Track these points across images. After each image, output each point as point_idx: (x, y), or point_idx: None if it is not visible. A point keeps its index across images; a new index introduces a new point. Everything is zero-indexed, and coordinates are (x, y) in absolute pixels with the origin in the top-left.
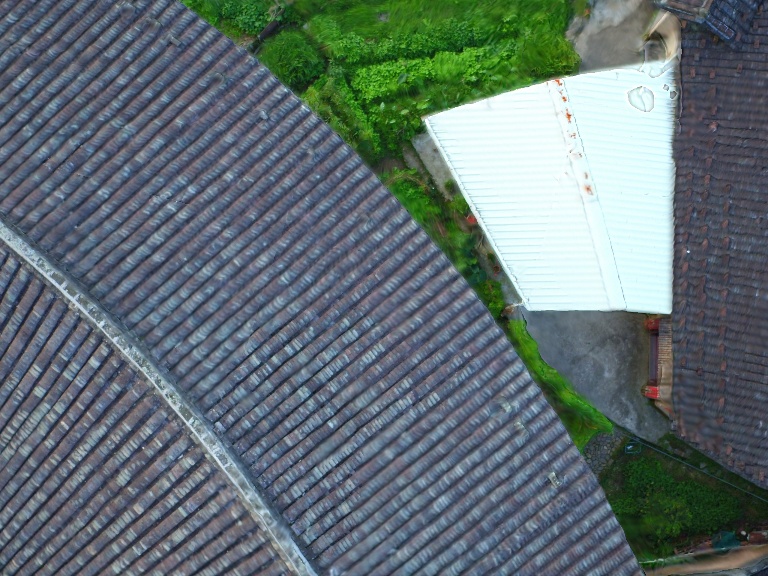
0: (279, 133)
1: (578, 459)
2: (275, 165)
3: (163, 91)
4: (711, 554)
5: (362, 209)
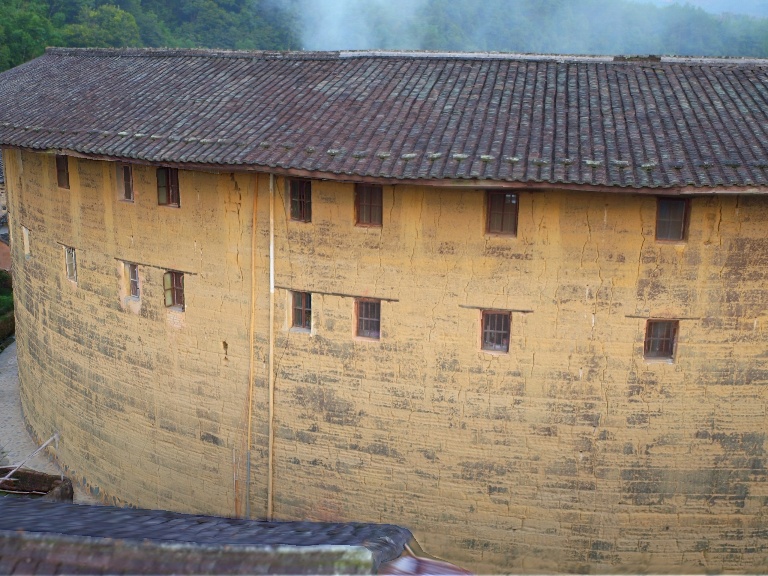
0: None
1: None
2: None
3: None
4: (1, 267)
5: None
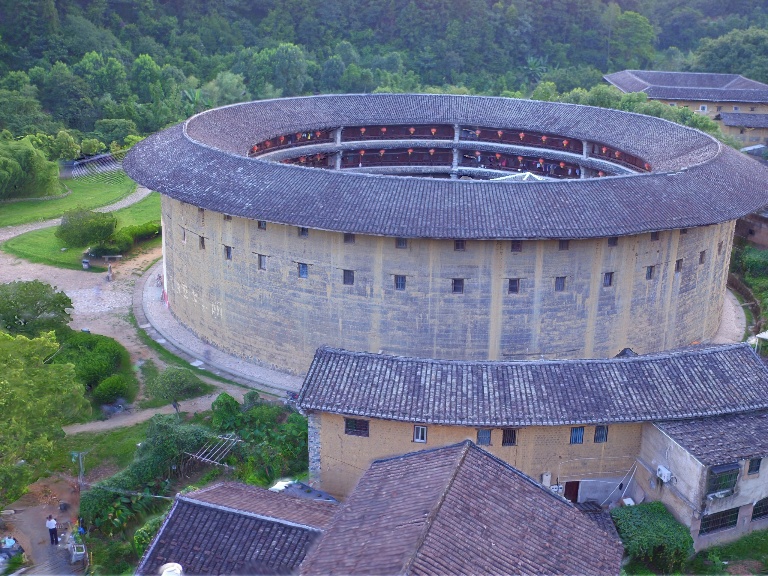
0: (767, 192)
1: (731, 217)
2: (759, 189)
3: (760, 181)
4: None
5: (761, 198)
